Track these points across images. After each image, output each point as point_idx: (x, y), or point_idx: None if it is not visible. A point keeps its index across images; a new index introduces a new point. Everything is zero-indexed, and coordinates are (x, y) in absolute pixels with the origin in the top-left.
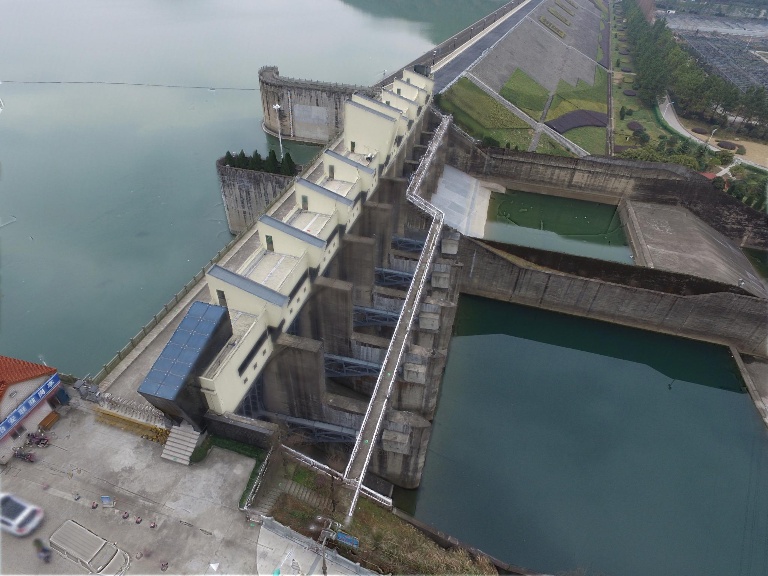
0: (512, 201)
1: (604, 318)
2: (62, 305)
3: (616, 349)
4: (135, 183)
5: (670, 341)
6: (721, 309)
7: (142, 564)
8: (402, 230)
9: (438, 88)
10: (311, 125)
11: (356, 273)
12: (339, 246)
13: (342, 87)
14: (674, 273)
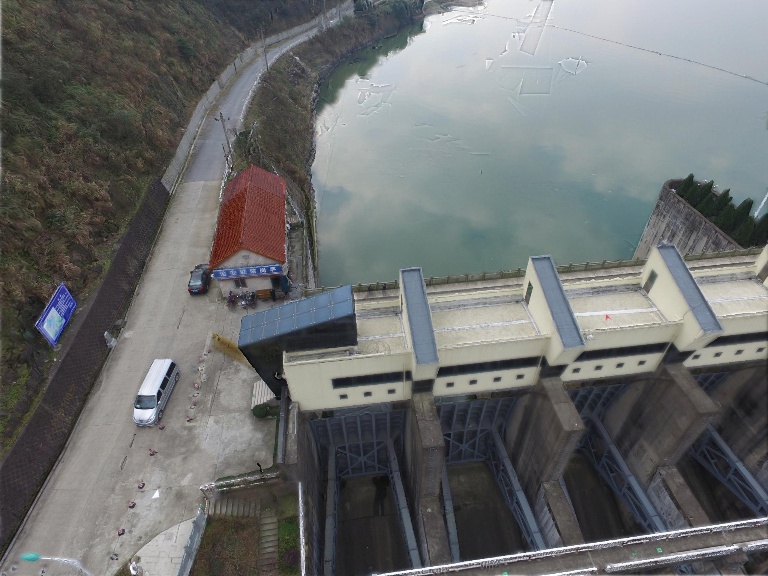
0: None
1: None
2: (438, 232)
3: None
4: (606, 168)
5: None
6: None
7: (155, 434)
8: None
9: None
10: None
11: (654, 425)
12: (656, 371)
13: None
14: None
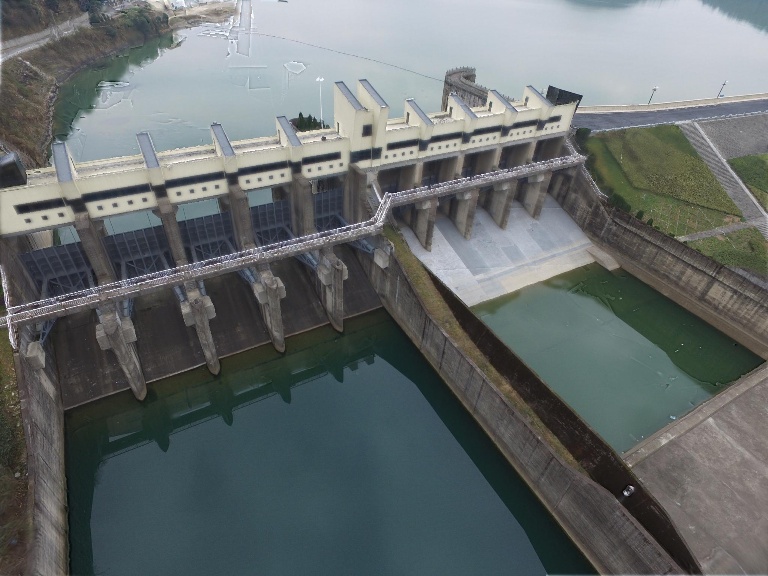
0: (606, 281)
1: (487, 429)
2: None
3: (499, 482)
4: None
5: (545, 516)
6: (601, 516)
7: None
8: None
9: (611, 126)
10: None
11: None
12: (229, 192)
13: None
14: (591, 431)
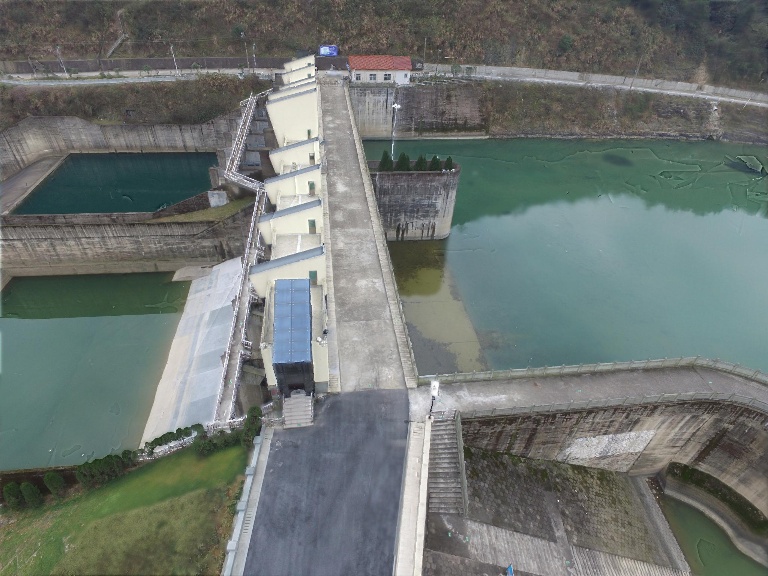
0: None
1: None
2: None
3: None
4: (619, 260)
5: None
6: None
7: None
8: None
9: None
10: None
11: None
12: None
13: (550, 409)
14: None
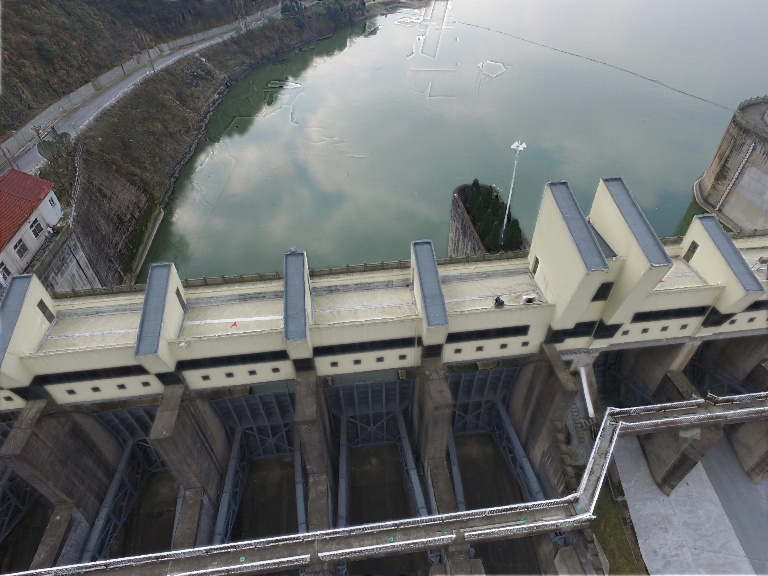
0: None
1: None
2: (278, 235)
3: None
4: (473, 172)
5: None
6: None
7: None
8: (539, 454)
9: None
10: (754, 208)
11: None
12: None
13: None
14: None
